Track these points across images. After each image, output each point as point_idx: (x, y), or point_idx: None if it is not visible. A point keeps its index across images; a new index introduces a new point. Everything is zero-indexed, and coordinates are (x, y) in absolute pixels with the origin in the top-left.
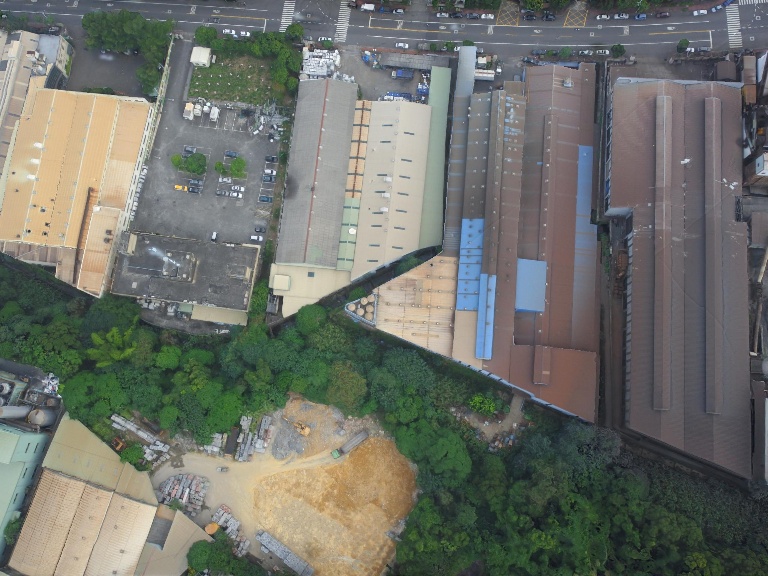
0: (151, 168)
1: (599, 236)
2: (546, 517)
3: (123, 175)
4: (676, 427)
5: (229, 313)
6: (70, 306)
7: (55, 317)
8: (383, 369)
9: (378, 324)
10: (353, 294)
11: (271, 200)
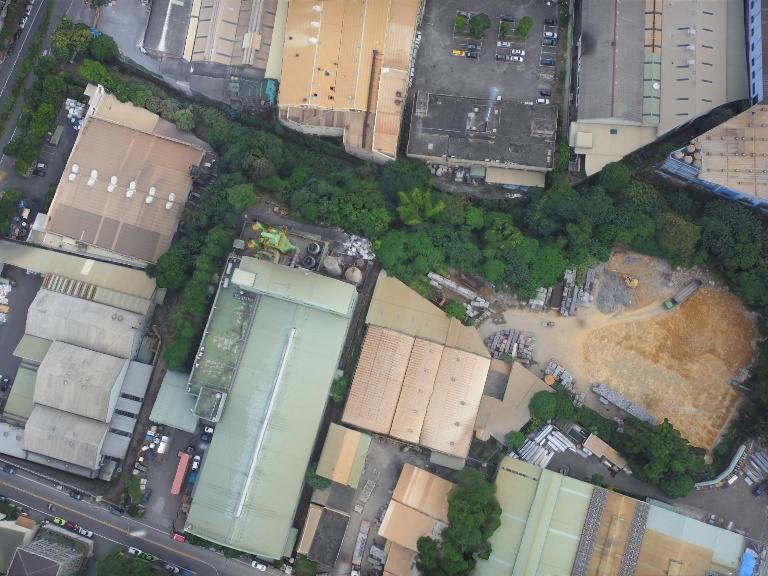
0: (424, 34)
1: None
2: None
3: (403, 39)
4: None
5: (525, 175)
6: (364, 169)
7: (349, 181)
8: (713, 218)
9: (700, 174)
10: (664, 148)
11: (554, 63)
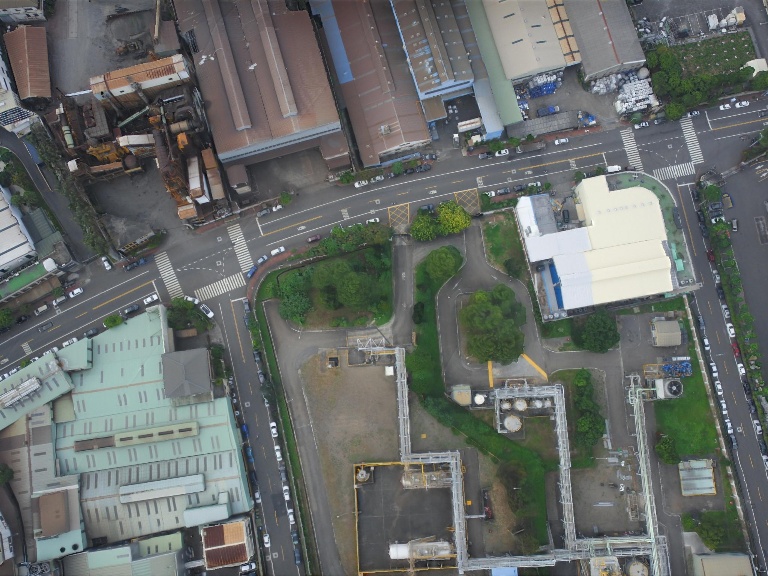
0: None
1: (308, 7)
2: None
3: None
4: None
5: None
6: None
7: None
8: None
9: None
10: None
11: None
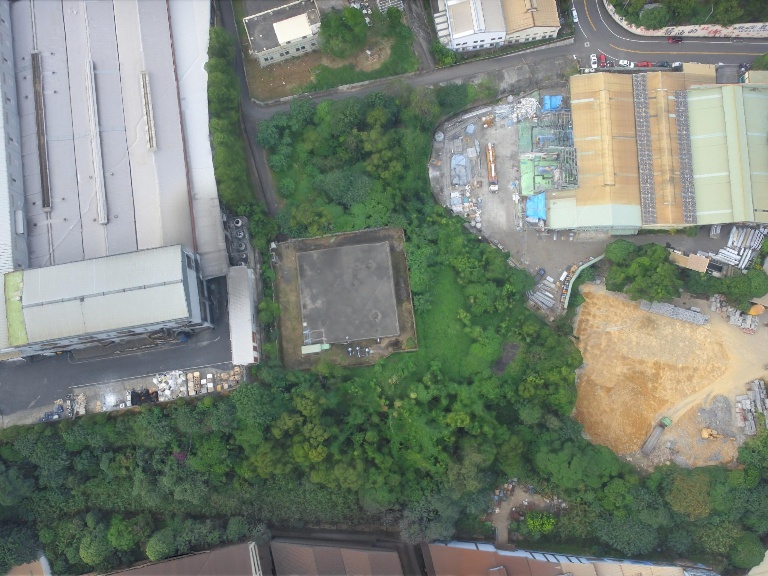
0: None
1: None
2: (457, 440)
3: None
4: (356, 571)
5: None
6: None
7: None
8: None
9: (681, 573)
10: None
11: None
